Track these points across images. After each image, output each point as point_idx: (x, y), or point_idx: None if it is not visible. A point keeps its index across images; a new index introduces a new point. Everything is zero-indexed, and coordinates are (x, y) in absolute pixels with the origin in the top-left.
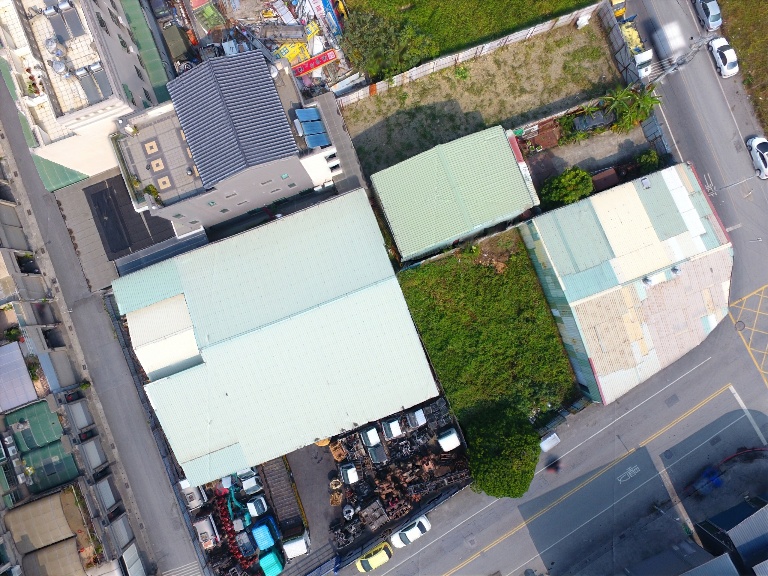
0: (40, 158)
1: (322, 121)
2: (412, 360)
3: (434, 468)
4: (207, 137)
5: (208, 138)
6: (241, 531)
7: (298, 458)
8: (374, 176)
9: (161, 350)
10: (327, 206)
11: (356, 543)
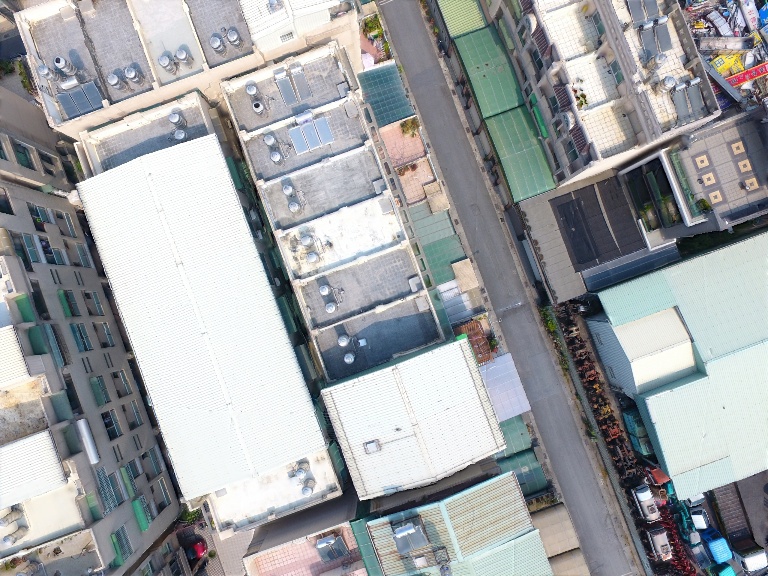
0: (512, 169)
1: None
2: None
3: None
4: None
5: None
6: (698, 543)
7: None
8: None
9: (654, 363)
10: None
11: None
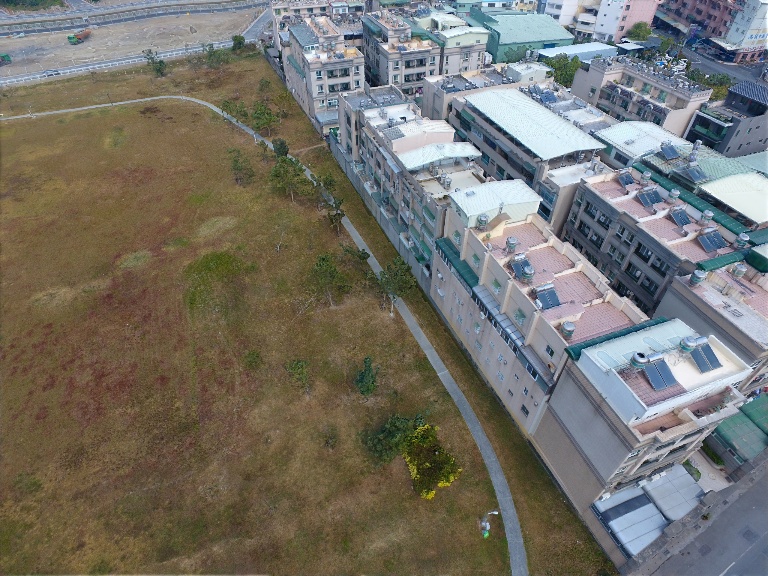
0: None
1: None
2: None
3: None
4: None
5: None
6: None
7: None
8: None
9: None
10: None
11: None
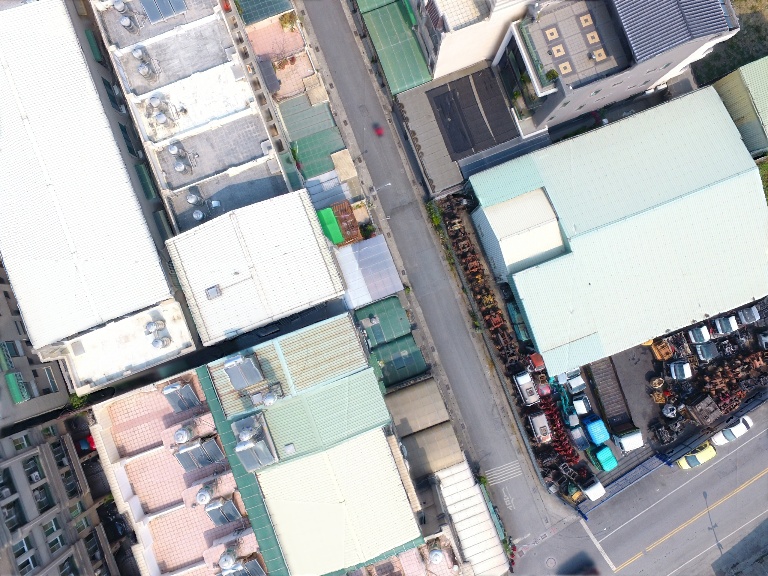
0: (388, 61)
1: (727, 5)
2: (765, 251)
3: (763, 364)
4: (645, 12)
5: (646, 13)
6: (576, 426)
7: (616, 359)
8: (743, 68)
9: (523, 242)
10: (677, 103)
11: (674, 442)
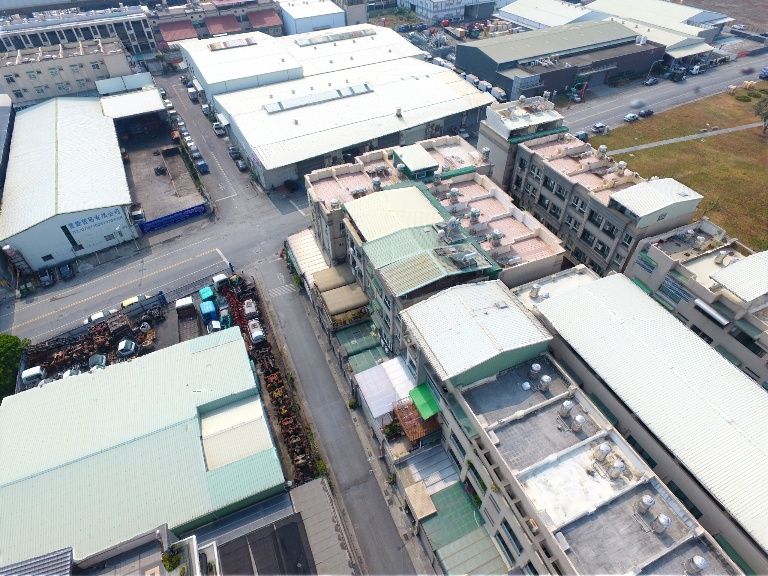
0: None
1: None
2: (8, 423)
3: None
4: None
5: None
6: (223, 310)
7: None
8: None
9: (240, 418)
10: None
11: None
